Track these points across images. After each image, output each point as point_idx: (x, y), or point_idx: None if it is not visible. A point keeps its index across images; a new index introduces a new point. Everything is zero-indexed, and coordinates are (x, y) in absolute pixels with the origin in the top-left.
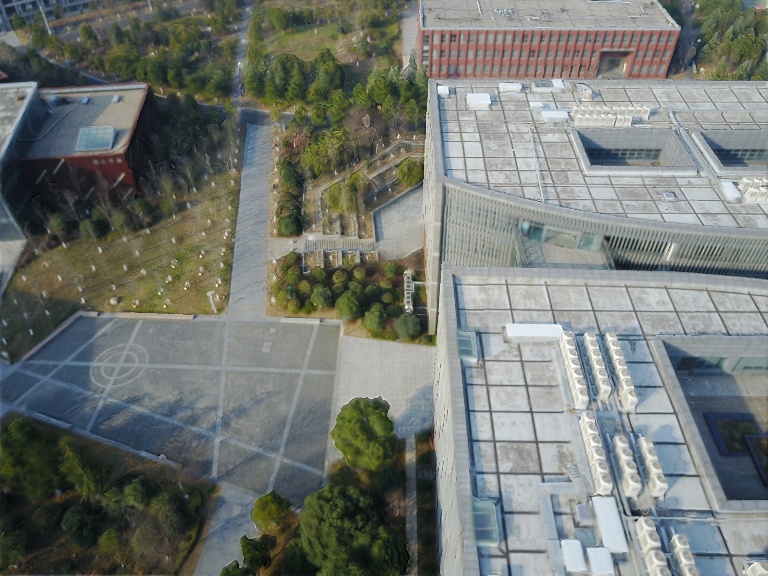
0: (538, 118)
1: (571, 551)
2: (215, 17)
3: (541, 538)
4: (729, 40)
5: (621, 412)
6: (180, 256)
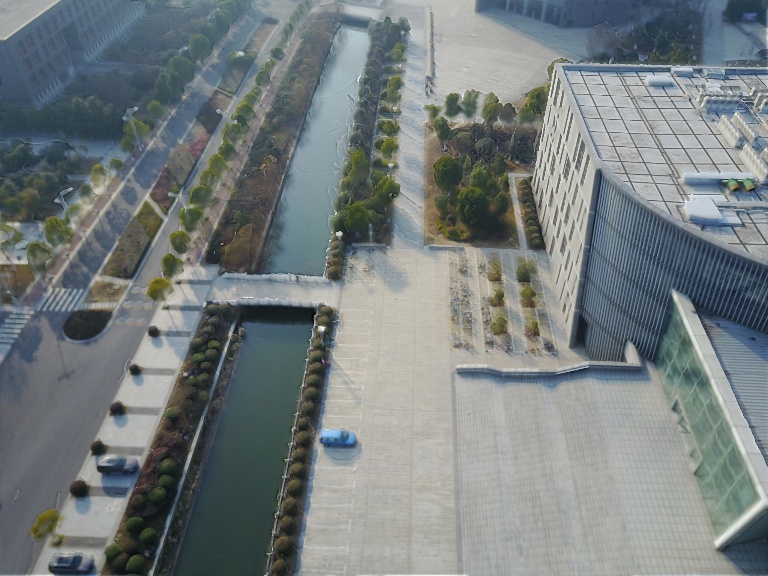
0: None
1: (714, 84)
2: None
3: None
4: None
5: None
6: None
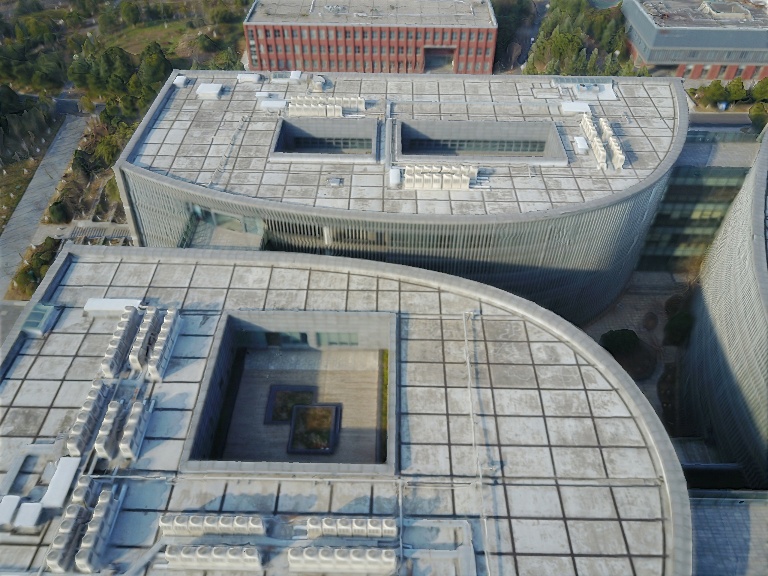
0: (259, 107)
1: (5, 506)
2: (76, 11)
3: None
4: None
5: (148, 381)
6: None
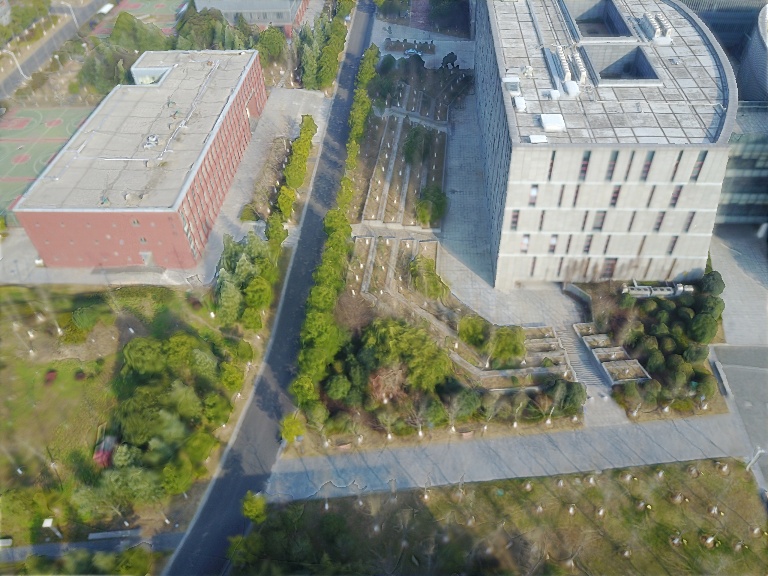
0: (573, 98)
1: None
2: None
3: None
4: (243, 47)
5: None
6: (657, 538)
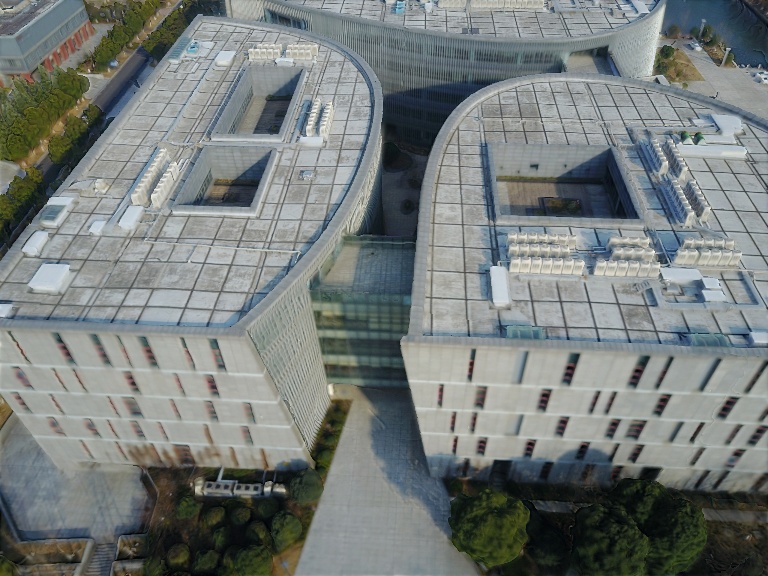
0: (123, 233)
1: (712, 296)
2: None
3: (702, 314)
4: None
5: (577, 252)
6: None
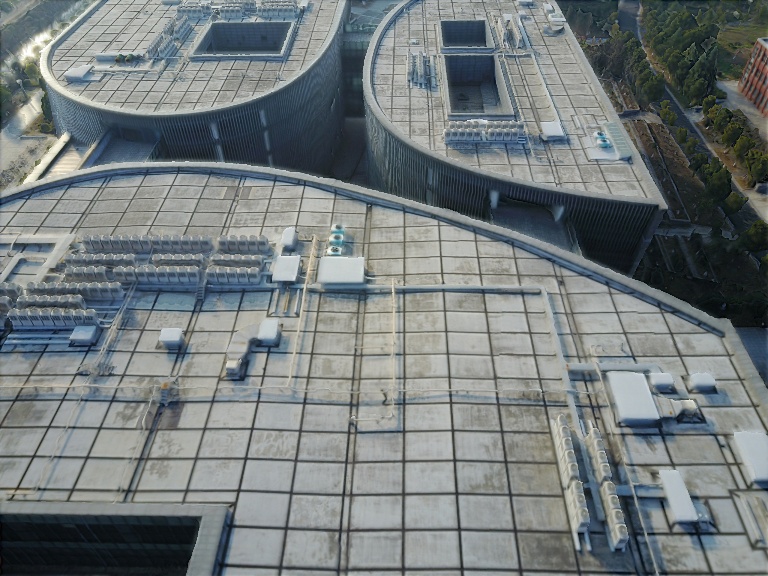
0: None
1: None
2: None
3: None
4: None
5: None
6: None
